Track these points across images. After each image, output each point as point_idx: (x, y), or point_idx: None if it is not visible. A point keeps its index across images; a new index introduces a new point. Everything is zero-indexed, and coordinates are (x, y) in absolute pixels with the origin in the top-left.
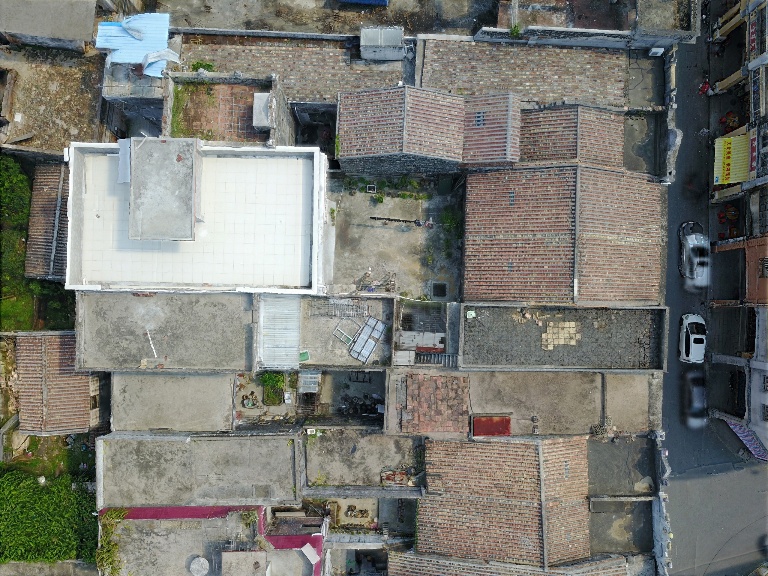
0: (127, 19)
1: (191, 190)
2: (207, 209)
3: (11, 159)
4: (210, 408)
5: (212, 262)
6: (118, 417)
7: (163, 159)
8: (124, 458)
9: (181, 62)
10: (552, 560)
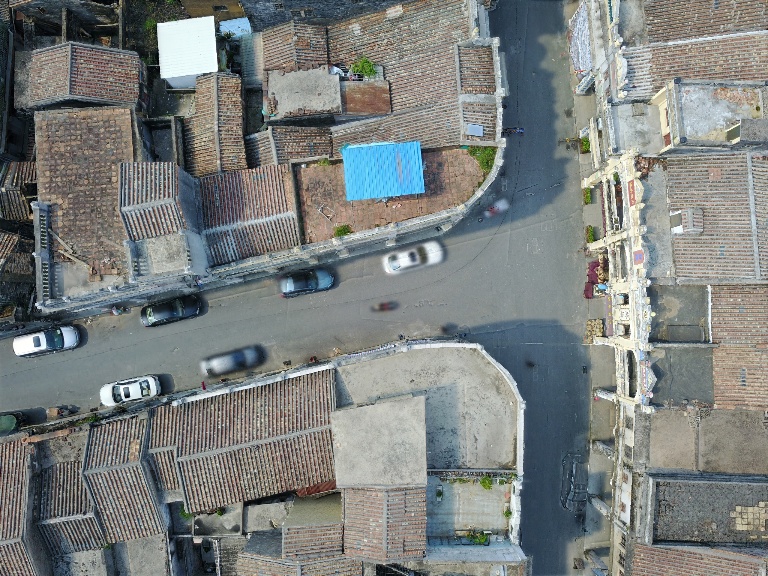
0: None
1: None
2: None
3: None
4: None
5: None
6: None
7: None
8: None
9: None
10: (767, 290)
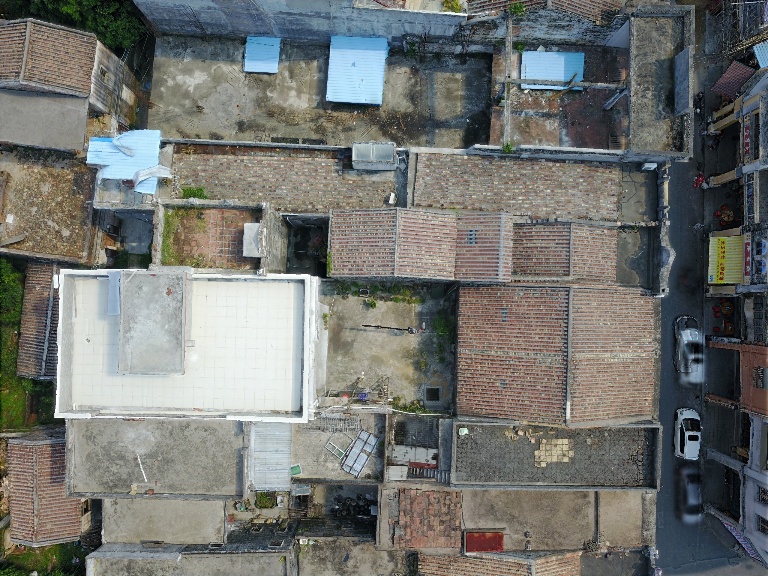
0: (118, 136)
1: (181, 324)
2: (198, 333)
3: (3, 259)
4: (202, 520)
5: (203, 387)
6: (109, 529)
7: (153, 292)
8: (115, 575)
9: (173, 172)
10: None
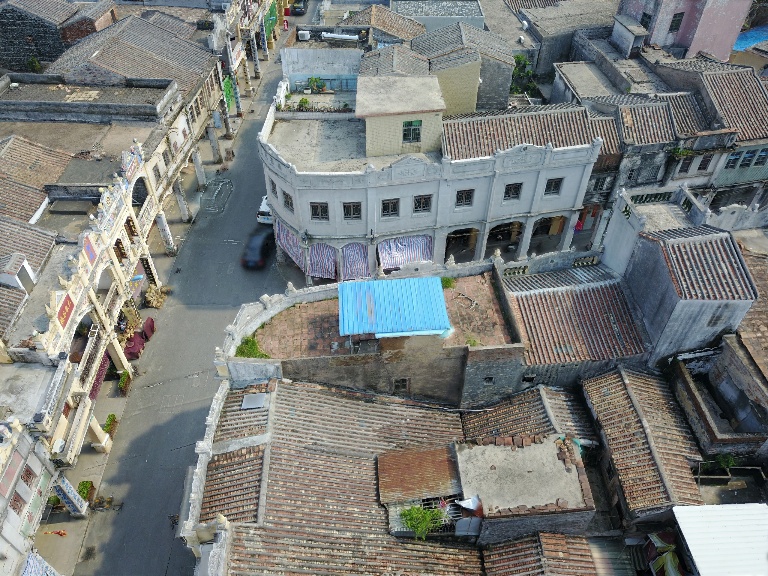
0: None
1: None
2: None
3: None
4: None
5: None
6: None
7: None
8: None
9: None
10: None
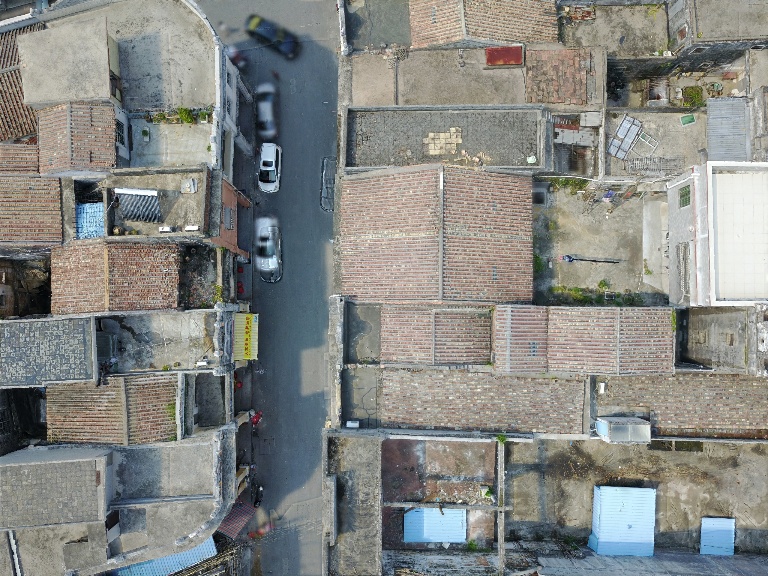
0: None
1: None
2: None
3: None
4: None
5: None
6: None
7: None
8: None
9: None
10: None
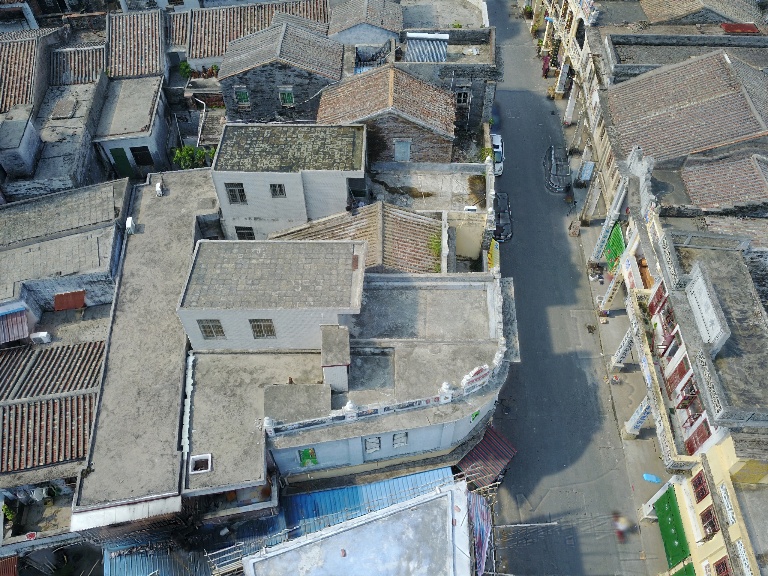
0: None
1: None
2: None
3: None
4: None
5: None
6: None
7: None
8: None
9: None
10: None
